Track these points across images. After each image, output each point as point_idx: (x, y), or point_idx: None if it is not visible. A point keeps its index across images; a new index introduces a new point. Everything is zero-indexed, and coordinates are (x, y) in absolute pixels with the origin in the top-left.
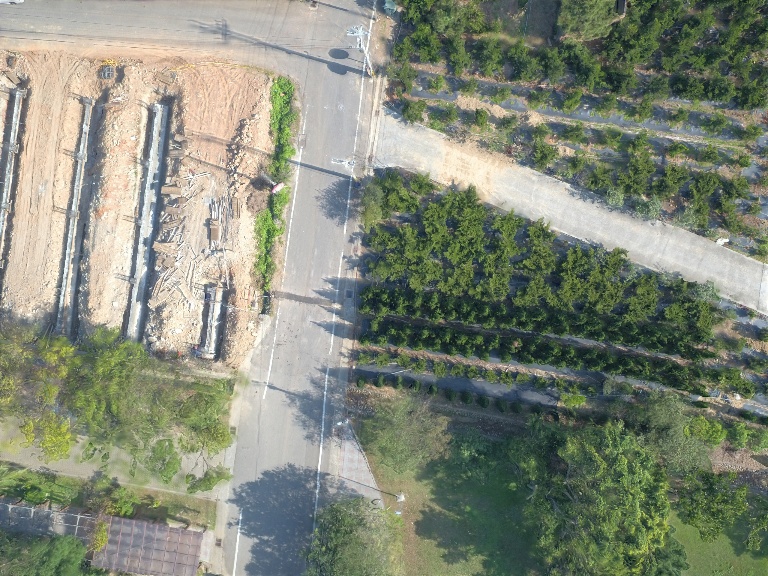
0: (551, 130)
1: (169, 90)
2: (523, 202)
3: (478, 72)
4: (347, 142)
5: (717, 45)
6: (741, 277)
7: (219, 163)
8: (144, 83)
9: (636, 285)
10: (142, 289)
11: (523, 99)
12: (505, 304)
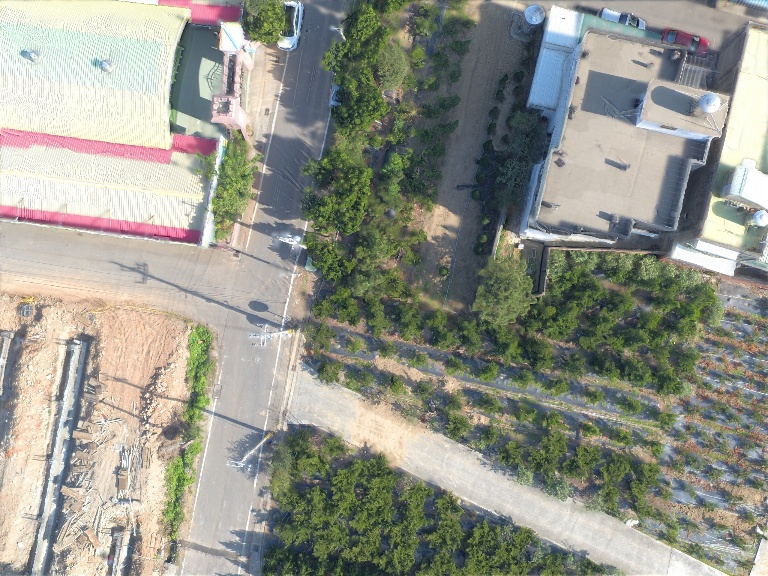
0: (467, 397)
1: (87, 331)
2: (434, 469)
3: (397, 333)
4: (262, 395)
5: (636, 328)
6: (649, 560)
7: (132, 410)
8: (63, 322)
9: (541, 566)
10: (50, 527)
11: (440, 364)
12: (411, 570)
